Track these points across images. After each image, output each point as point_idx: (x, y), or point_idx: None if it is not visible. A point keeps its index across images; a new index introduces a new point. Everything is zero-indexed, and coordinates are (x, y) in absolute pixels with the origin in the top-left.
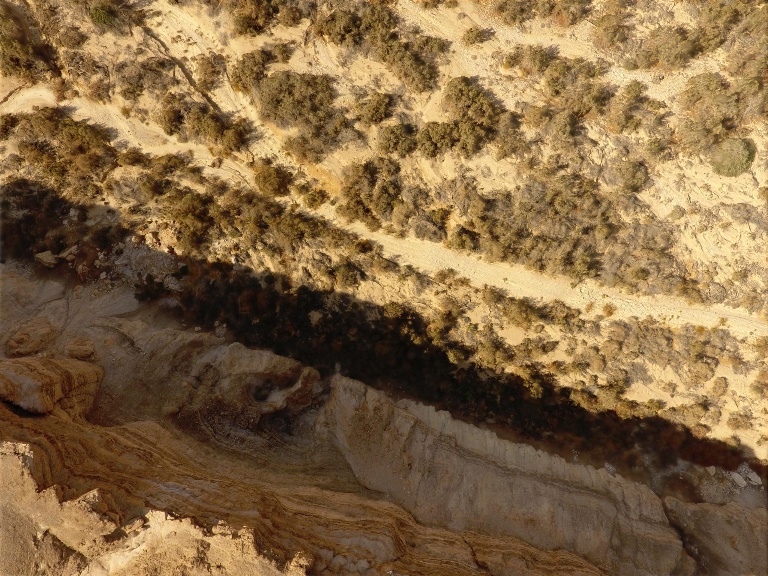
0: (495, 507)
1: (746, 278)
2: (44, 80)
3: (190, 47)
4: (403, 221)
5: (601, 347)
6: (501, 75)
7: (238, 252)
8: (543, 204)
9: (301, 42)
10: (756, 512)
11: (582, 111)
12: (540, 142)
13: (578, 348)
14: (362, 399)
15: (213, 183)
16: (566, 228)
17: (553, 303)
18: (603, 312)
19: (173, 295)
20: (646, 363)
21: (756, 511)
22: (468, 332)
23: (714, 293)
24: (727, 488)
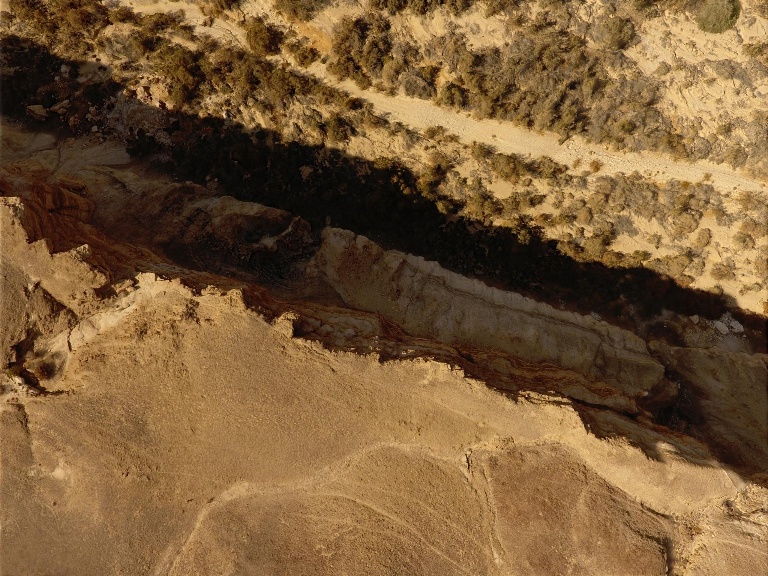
0: (482, 328)
1: (730, 132)
2: None
3: None
4: (393, 77)
5: (588, 200)
6: None
7: (229, 108)
8: (531, 57)
9: None
10: (738, 354)
11: None
12: None
13: (565, 201)
14: (352, 242)
15: (204, 41)
16: (554, 82)
17: (541, 158)
18: (590, 168)
19: (165, 151)
20: (632, 215)
21: (738, 354)
22: (457, 186)
23: (699, 147)
24: (710, 335)
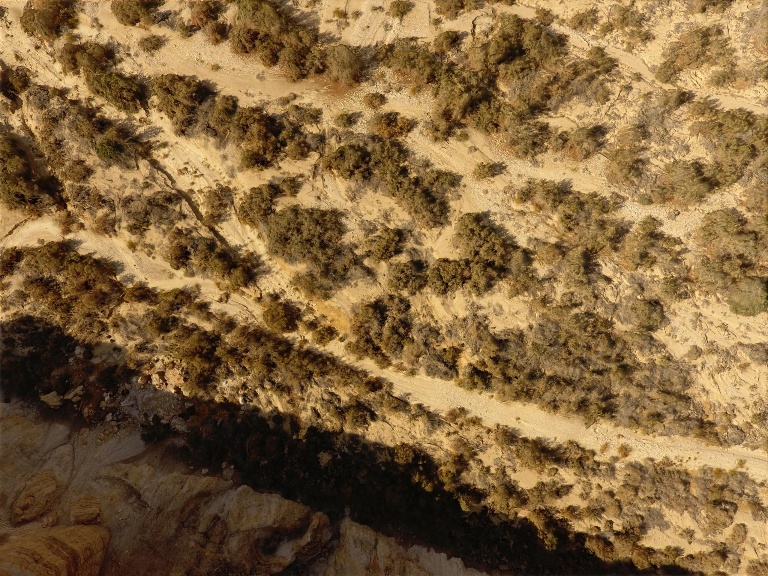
0: None
1: (765, 421)
2: (49, 213)
3: (197, 179)
4: (413, 360)
5: (616, 491)
6: (513, 210)
7: (246, 391)
8: (557, 346)
9: (309, 176)
10: None
11: (596, 248)
12: (553, 280)
13: (593, 492)
14: (373, 553)
15: (220, 319)
16: (580, 370)
17: (567, 444)
18: (618, 453)
19: (180, 435)
20: (663, 508)
21: None
22: (480, 475)
23: (732, 436)
24: None
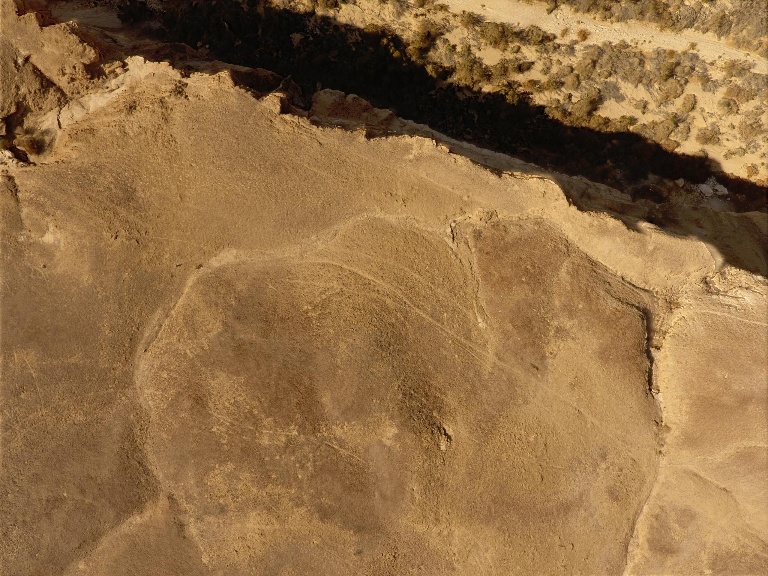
0: None
1: (715, 0)
2: None
3: None
4: None
5: (575, 66)
6: None
7: None
8: None
9: None
10: None
11: None
12: None
13: (553, 68)
14: None
15: None
16: None
17: (529, 27)
18: (578, 37)
19: (156, 18)
20: (618, 81)
21: None
22: (446, 53)
23: (684, 14)
24: (695, 197)
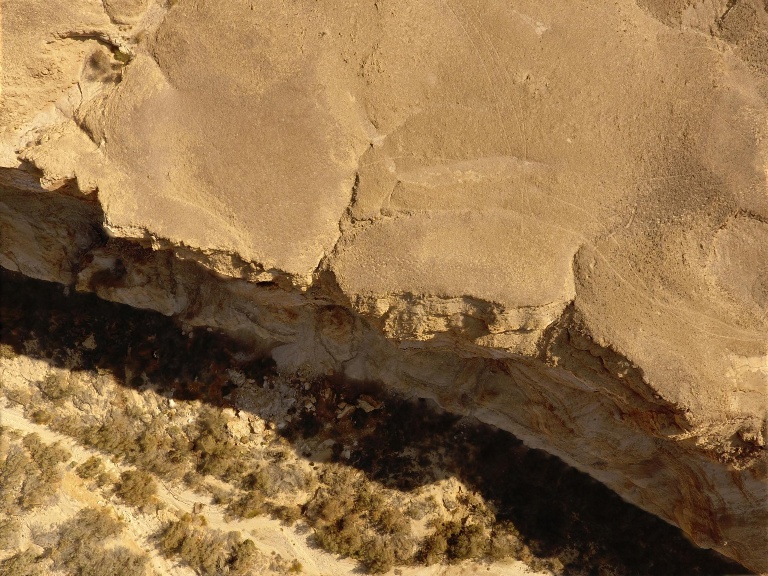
0: None
1: None
2: None
3: None
4: None
5: None
6: None
7: (170, 411)
8: None
9: None
10: None
11: None
12: None
13: None
14: (17, 262)
15: (201, 486)
16: None
17: None
18: None
19: (239, 364)
20: None
21: None
22: None
23: None
24: None
